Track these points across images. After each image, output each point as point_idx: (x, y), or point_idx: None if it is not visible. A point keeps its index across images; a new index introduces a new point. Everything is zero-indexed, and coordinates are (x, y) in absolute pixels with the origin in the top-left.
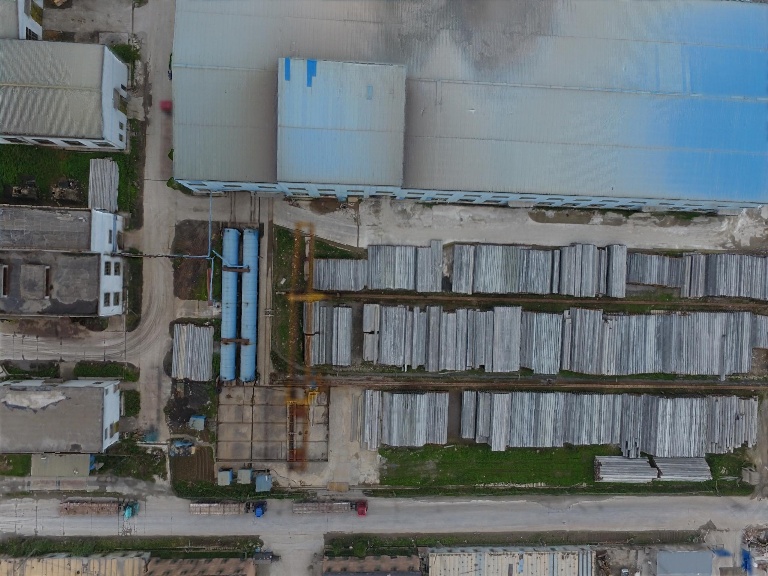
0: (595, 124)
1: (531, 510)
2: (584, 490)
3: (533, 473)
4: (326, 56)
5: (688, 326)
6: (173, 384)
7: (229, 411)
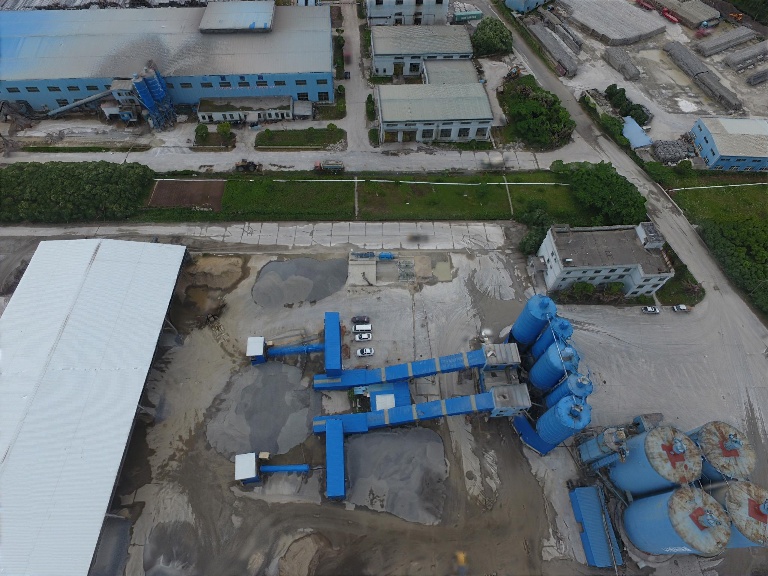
0: (89, 26)
1: None
2: None
3: None
4: (245, 39)
5: (56, 0)
6: None
7: None
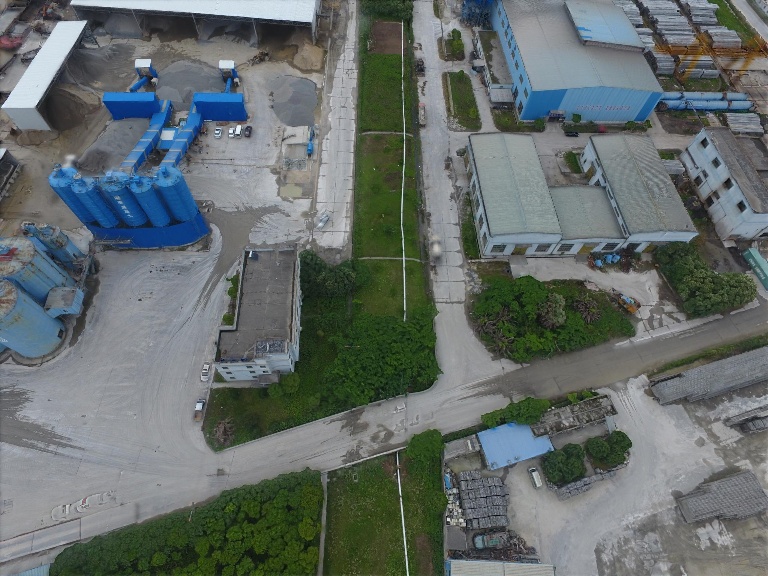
0: None
1: (736, 2)
2: None
3: (718, 1)
4: (566, 31)
5: None
6: (767, 133)
7: (765, 110)
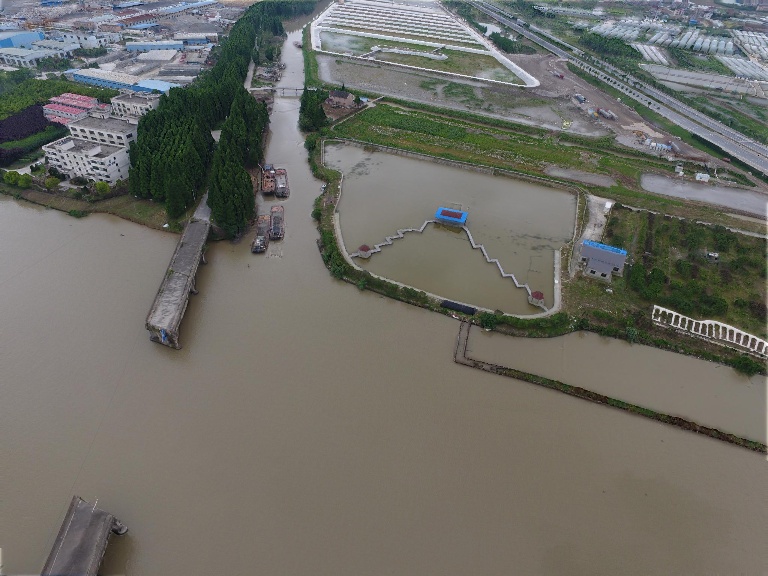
0: None
1: None
2: (36, 27)
3: None
4: None
5: None
6: None
7: None
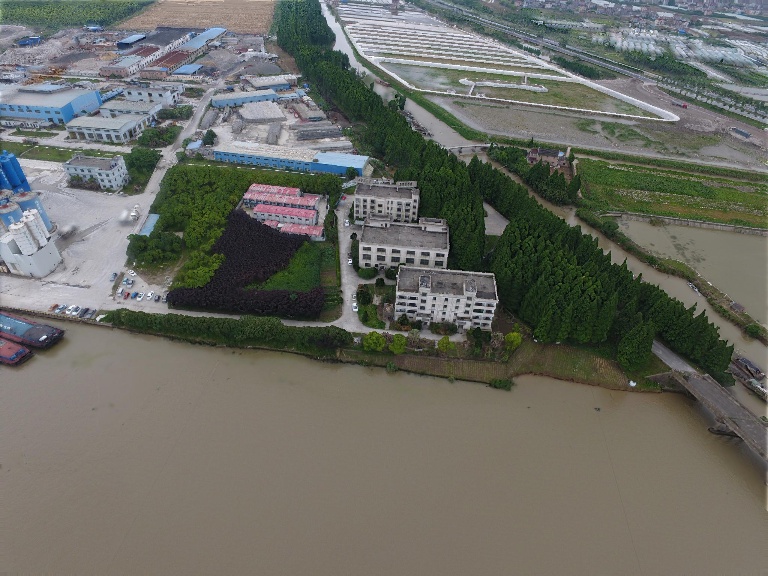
0: None
1: None
2: (48, 77)
3: None
4: None
5: None
6: None
7: None
